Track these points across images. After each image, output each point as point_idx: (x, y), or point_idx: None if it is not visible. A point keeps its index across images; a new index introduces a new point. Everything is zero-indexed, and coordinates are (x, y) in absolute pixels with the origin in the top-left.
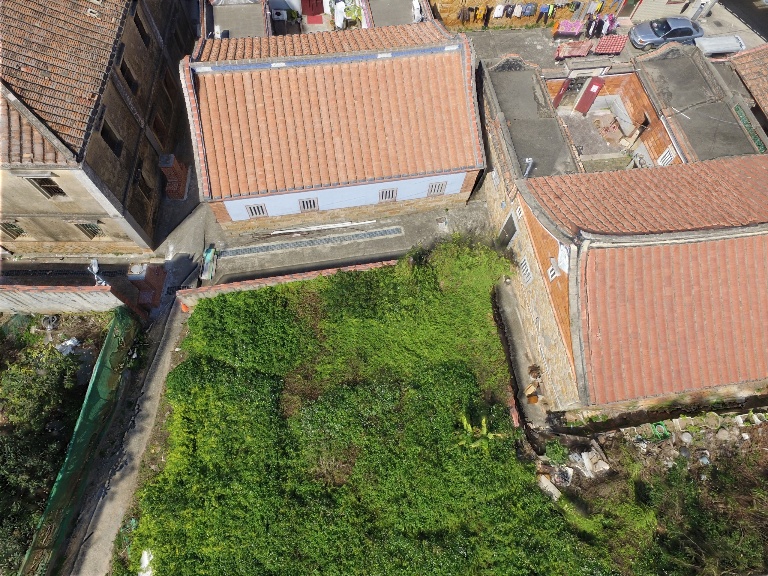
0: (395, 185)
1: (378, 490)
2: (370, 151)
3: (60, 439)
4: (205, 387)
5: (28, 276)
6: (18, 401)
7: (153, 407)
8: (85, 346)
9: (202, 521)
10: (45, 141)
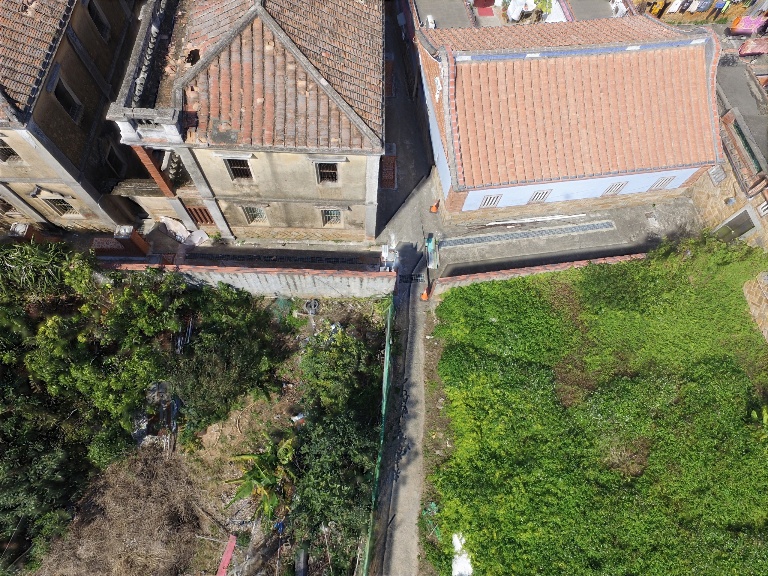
0: (629, 178)
1: (680, 481)
2: (614, 144)
3: None
4: (479, 375)
5: (254, 261)
6: (324, 383)
7: (420, 393)
8: (348, 331)
9: (511, 506)
10: (351, 126)
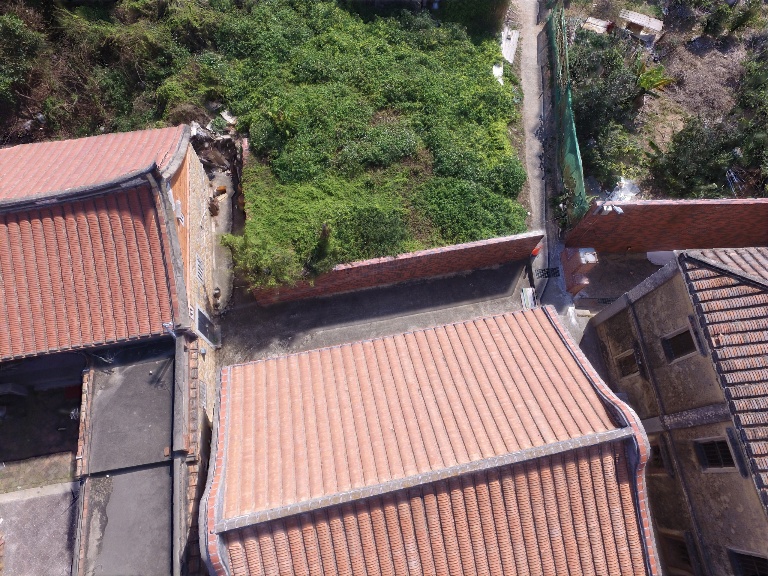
0: None
1: None
2: (369, 372)
3: (582, 123)
4: None
5: None
6: (623, 137)
7: (531, 170)
8: None
9: None
10: None
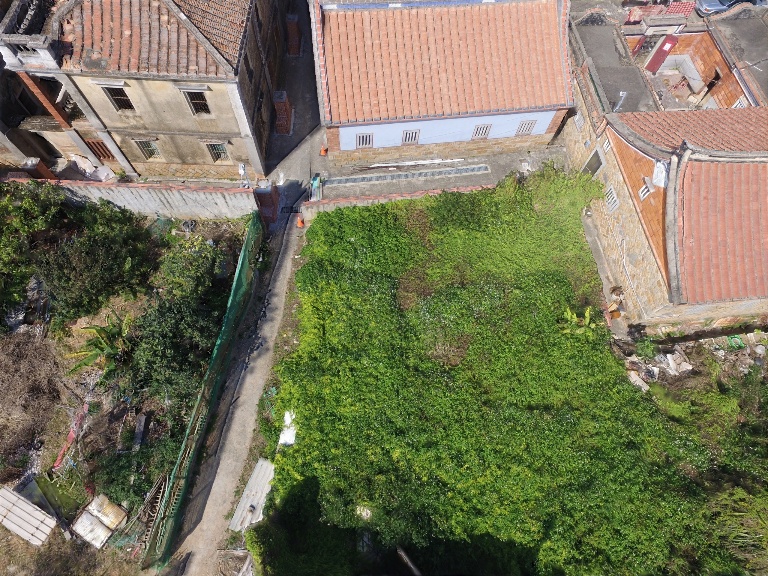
0: (490, 121)
1: (491, 369)
2: (472, 87)
3: None
4: (330, 283)
5: None
6: (178, 280)
7: (280, 302)
8: (220, 247)
9: (338, 388)
10: (208, 56)
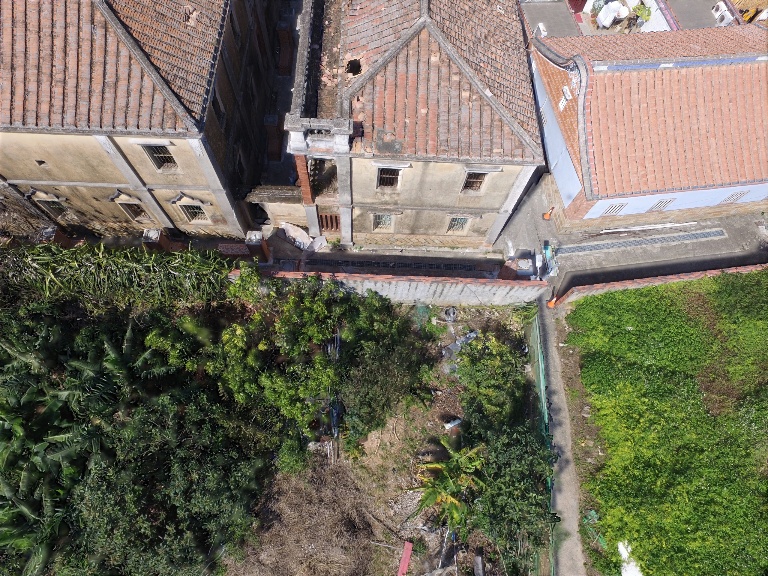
0: (752, 188)
1: None
2: (742, 153)
3: None
4: (625, 383)
5: (373, 267)
6: (486, 391)
7: (561, 401)
8: None
9: (676, 515)
10: (513, 137)
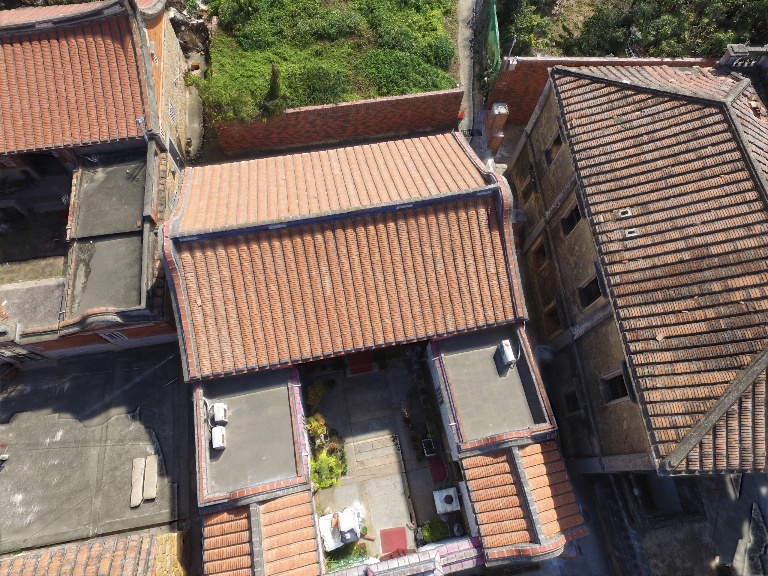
0: None
1: None
2: None
3: (503, 6)
4: None
5: None
6: None
7: (462, 51)
8: None
9: None
10: None
